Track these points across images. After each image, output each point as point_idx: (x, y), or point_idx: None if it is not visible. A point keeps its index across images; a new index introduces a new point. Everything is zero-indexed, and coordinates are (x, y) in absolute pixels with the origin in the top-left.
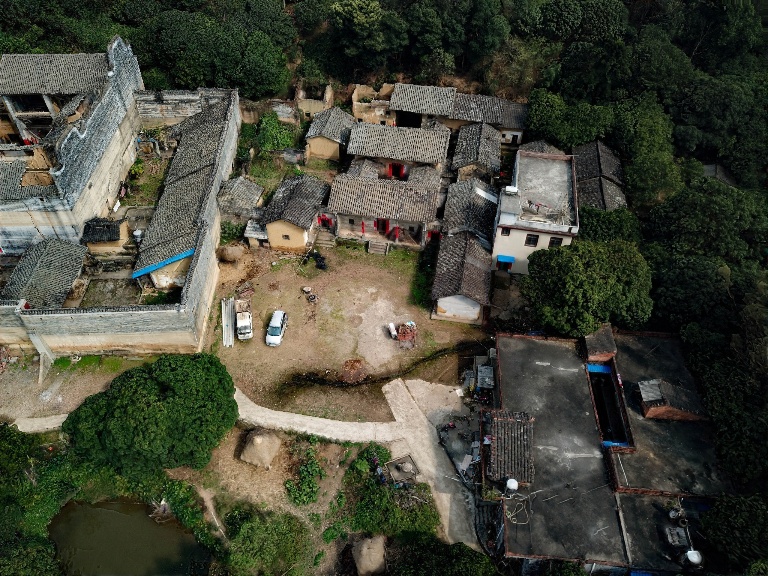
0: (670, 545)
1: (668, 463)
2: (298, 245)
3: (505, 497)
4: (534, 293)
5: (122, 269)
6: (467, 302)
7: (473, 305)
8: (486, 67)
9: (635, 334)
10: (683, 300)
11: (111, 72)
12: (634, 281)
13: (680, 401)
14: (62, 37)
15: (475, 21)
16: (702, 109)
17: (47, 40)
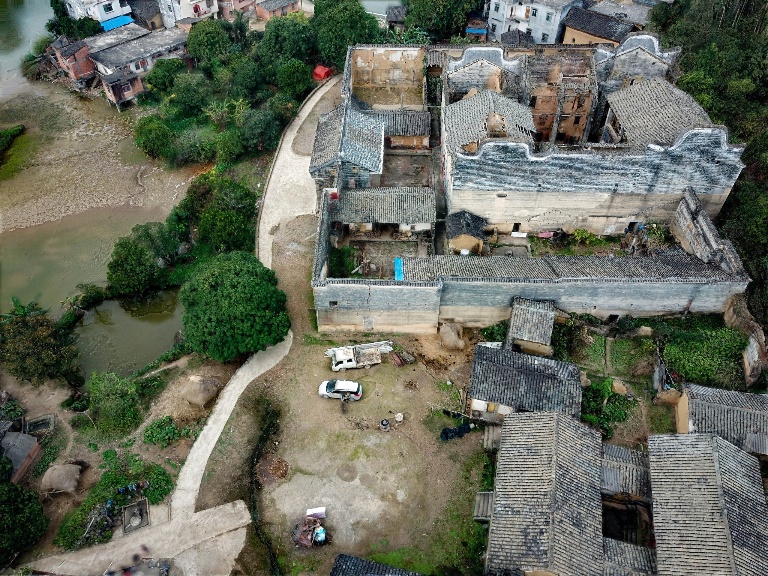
0: None
1: None
2: None
3: None
4: None
5: None
6: None
7: None
8: None
9: None
10: None
11: (660, 147)
12: None
13: None
14: None
15: None
16: None
17: (760, 103)
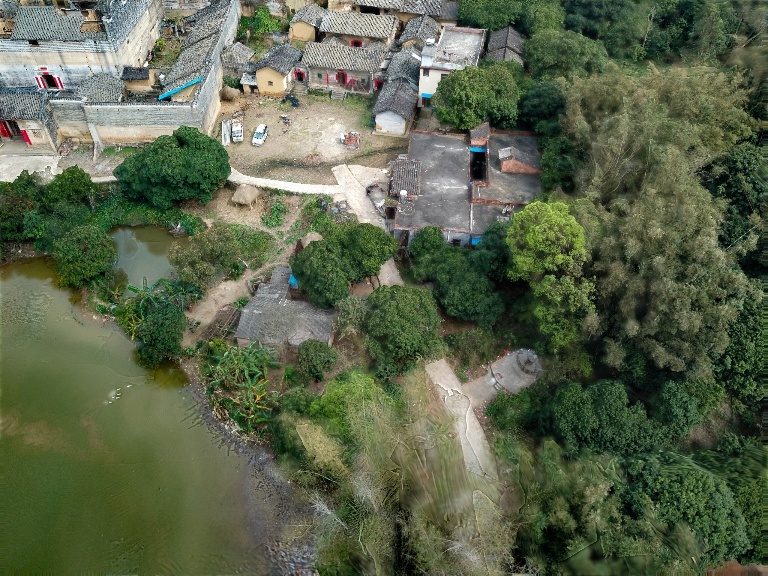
0: None
1: (510, 192)
2: (279, 90)
3: (399, 203)
4: (437, 101)
5: None
6: (395, 118)
7: (400, 121)
8: None
9: (507, 133)
10: (538, 106)
11: None
12: (503, 90)
13: (523, 159)
14: None
15: None
16: (586, 1)
17: None
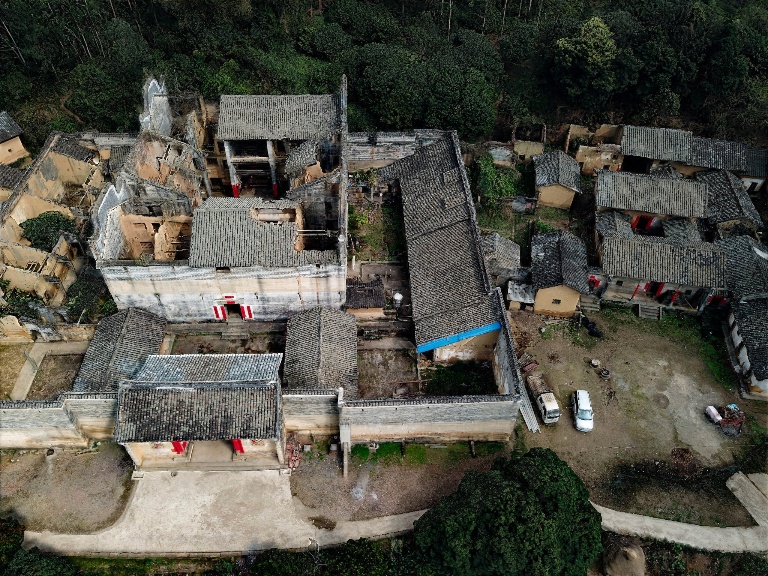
0: None
1: None
2: (567, 309)
3: None
4: None
5: (385, 337)
6: None
7: None
8: (711, 107)
9: None
10: None
11: None
12: None
13: None
14: (251, 70)
15: (714, 61)
16: None
17: None
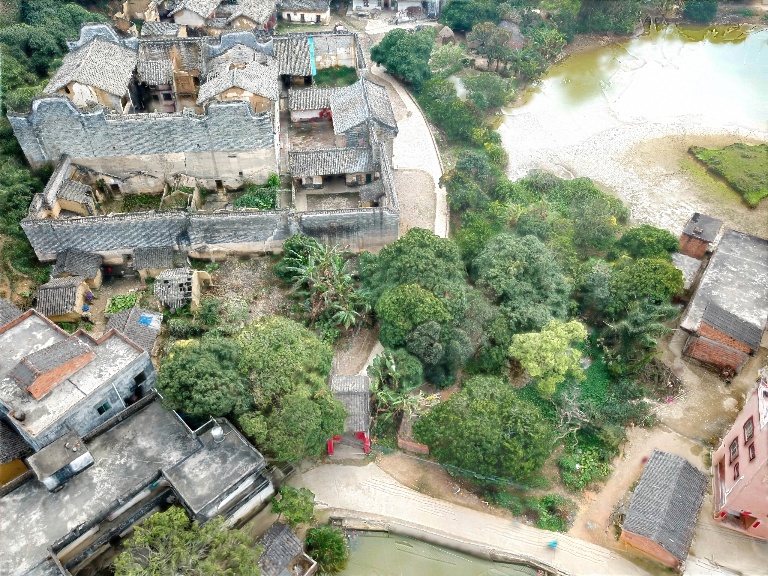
0: None
1: None
2: None
3: None
4: None
5: None
6: None
7: None
8: None
9: None
10: None
11: None
12: None
13: None
14: None
15: None
16: None
17: None
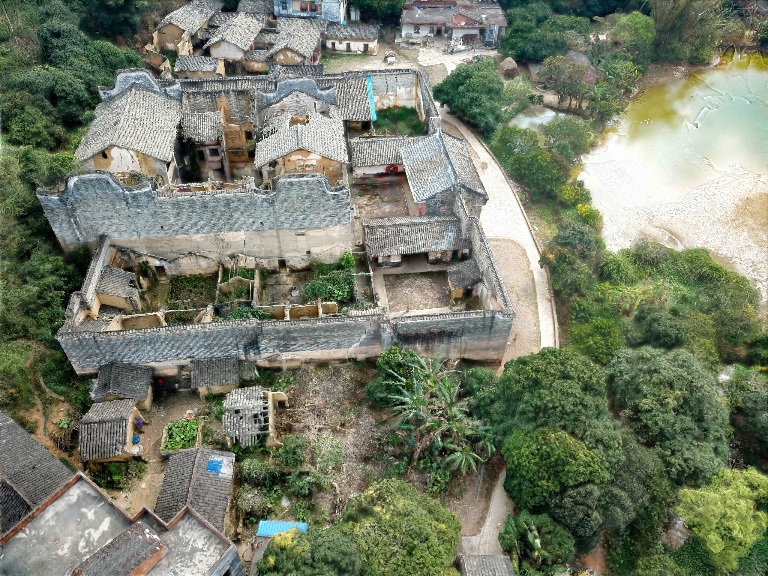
0: (490, 3)
1: None
2: None
3: None
4: None
5: None
6: None
7: None
8: None
9: None
10: None
11: None
12: None
13: None
14: None
15: None
16: None
17: None
